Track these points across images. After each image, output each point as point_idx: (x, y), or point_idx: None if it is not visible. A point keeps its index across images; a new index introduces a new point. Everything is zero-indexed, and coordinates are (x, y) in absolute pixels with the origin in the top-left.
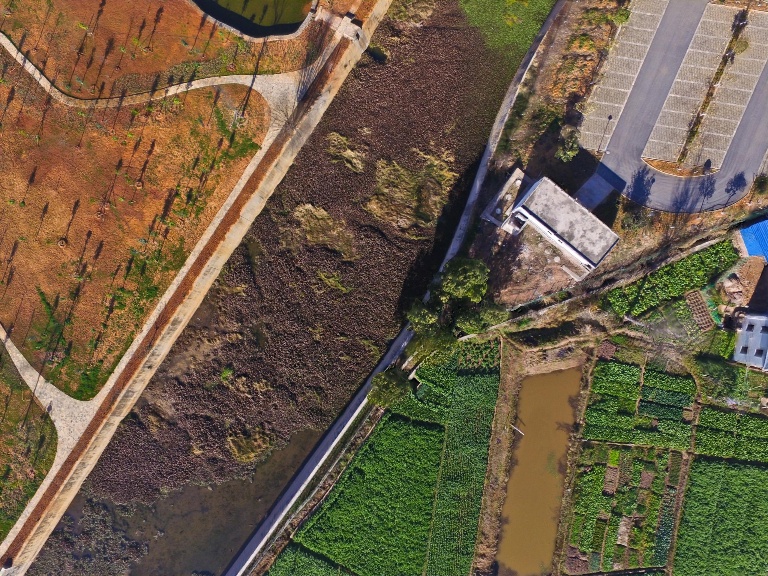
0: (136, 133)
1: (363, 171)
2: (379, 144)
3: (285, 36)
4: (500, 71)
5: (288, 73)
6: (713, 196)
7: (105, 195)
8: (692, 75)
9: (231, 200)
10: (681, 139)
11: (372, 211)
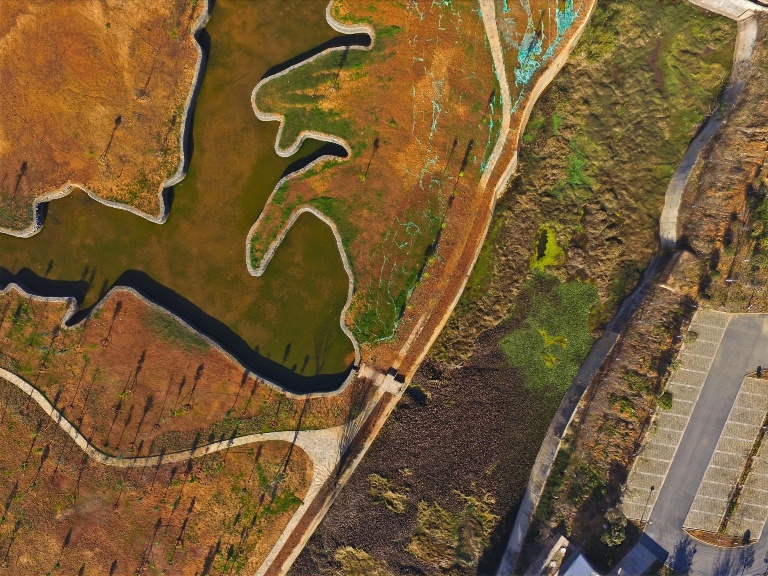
0: (175, 491)
1: (404, 512)
2: (420, 485)
3: (328, 393)
4: (539, 412)
5: (331, 428)
6: (753, 566)
7: (143, 555)
8: (731, 446)
9: (273, 556)
10: (721, 510)
11: (413, 552)
